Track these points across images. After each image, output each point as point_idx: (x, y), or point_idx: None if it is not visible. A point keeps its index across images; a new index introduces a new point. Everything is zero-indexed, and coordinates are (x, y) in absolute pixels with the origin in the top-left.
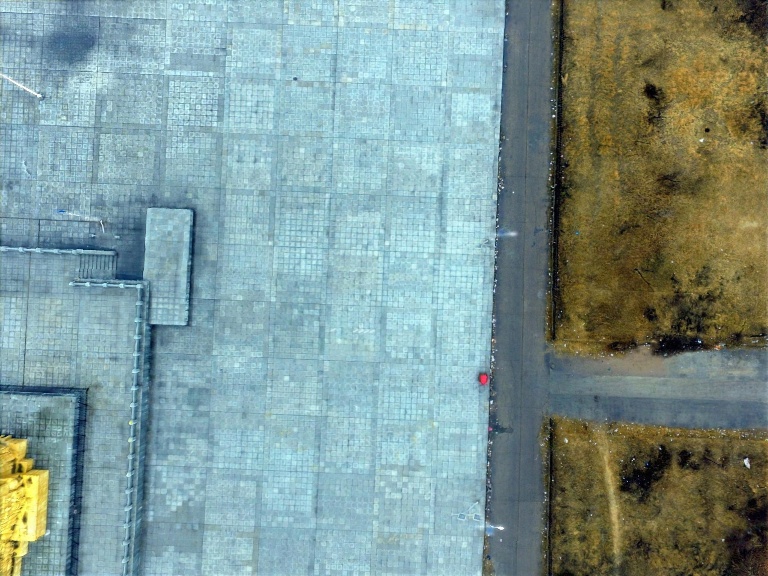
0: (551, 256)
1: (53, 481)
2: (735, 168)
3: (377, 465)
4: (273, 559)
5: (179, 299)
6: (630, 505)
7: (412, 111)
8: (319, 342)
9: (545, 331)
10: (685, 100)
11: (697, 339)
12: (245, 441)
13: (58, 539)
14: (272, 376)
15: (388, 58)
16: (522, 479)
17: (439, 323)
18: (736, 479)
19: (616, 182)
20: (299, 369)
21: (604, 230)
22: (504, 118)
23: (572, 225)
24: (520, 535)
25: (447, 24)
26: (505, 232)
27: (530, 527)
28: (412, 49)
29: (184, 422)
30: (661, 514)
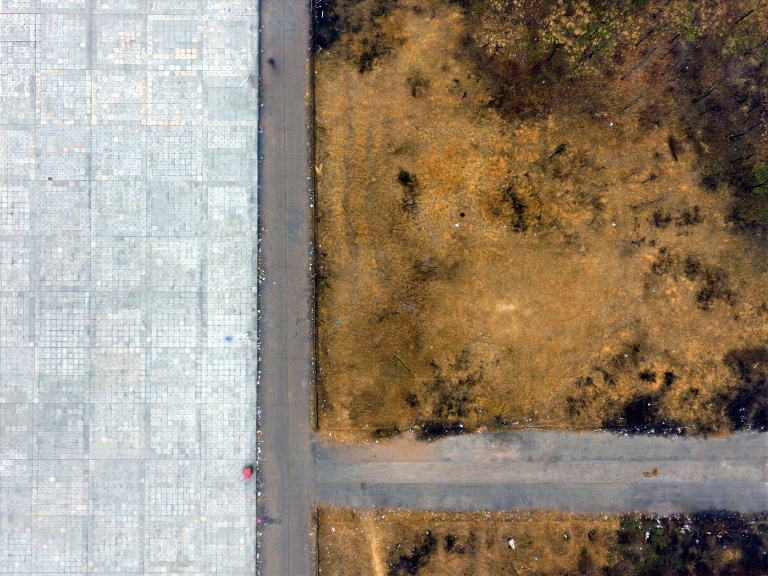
0: (313, 345)
1: None
2: (490, 252)
3: (146, 562)
4: None
5: None
6: None
7: (169, 207)
8: (84, 442)
9: (310, 420)
10: (438, 186)
11: (459, 423)
12: (12, 544)
13: None
14: (37, 478)
15: (143, 155)
16: (292, 569)
17: (203, 417)
18: (501, 561)
19: (374, 270)
20: (64, 470)
21: (363, 318)
22: (262, 209)
23: (332, 314)
24: None
25: (200, 118)
26: (267, 323)
27: None
28: (166, 145)
29: None
30: None
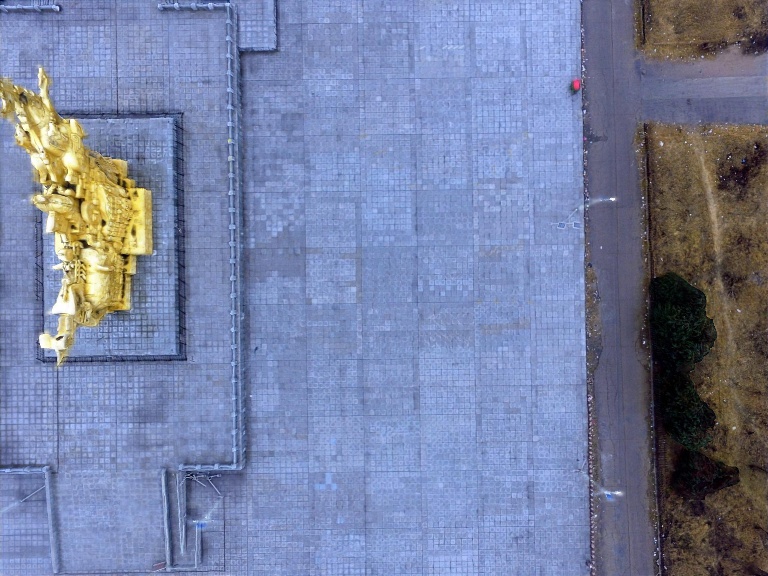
0: None
1: (156, 202)
2: None
3: (474, 179)
4: (376, 278)
5: (267, 21)
6: (728, 202)
7: None
8: (409, 60)
9: (634, 37)
10: None
11: None
12: (341, 163)
13: (165, 259)
14: (364, 97)
15: None
16: (619, 186)
17: (528, 34)
18: None
19: None
20: (391, 89)
21: None
22: None
23: None
24: (620, 241)
25: None
26: None
27: (629, 233)
28: None
29: (279, 148)
30: (760, 209)
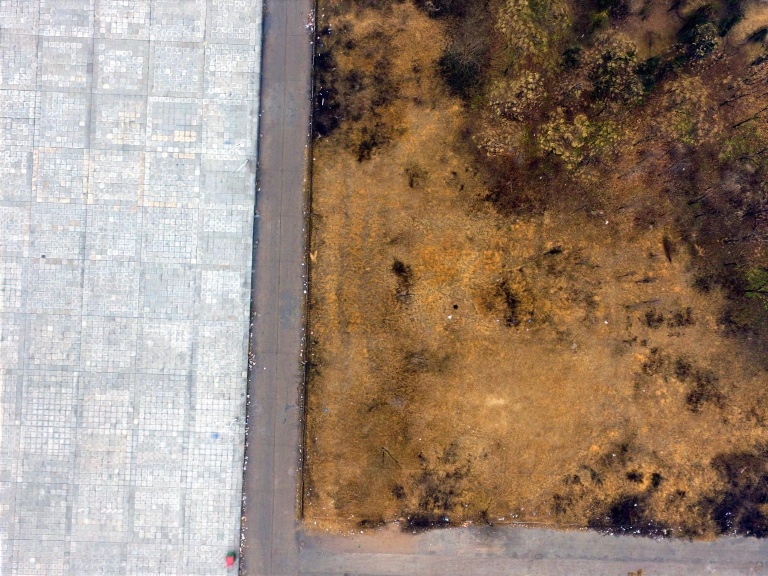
0: (302, 433)
1: None
2: (482, 345)
3: None
4: None
5: None
6: None
7: (161, 288)
8: (66, 523)
9: (295, 508)
10: (432, 278)
11: (444, 517)
12: None
13: None
14: (17, 558)
15: (137, 235)
16: None
17: (188, 502)
18: None
19: (365, 359)
20: (45, 550)
21: (352, 408)
22: (256, 294)
23: (321, 402)
24: None
25: (197, 201)
26: (256, 408)
27: None
28: (161, 226)
29: None
30: None
